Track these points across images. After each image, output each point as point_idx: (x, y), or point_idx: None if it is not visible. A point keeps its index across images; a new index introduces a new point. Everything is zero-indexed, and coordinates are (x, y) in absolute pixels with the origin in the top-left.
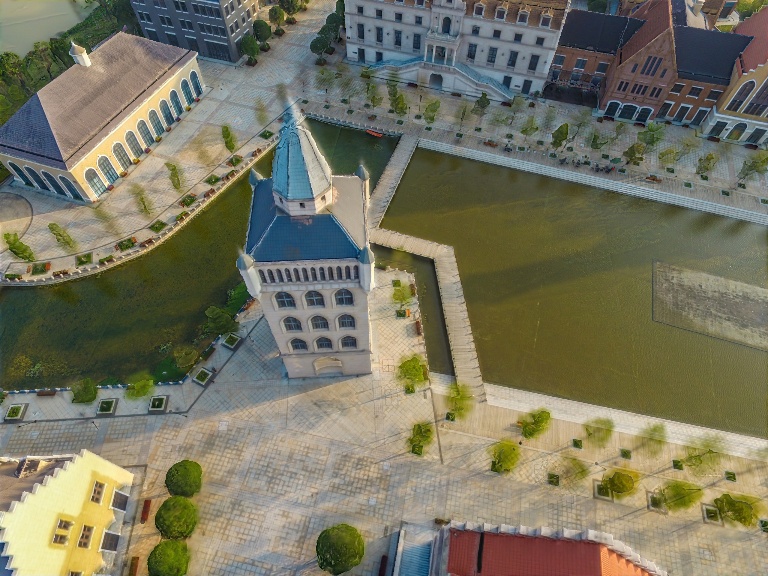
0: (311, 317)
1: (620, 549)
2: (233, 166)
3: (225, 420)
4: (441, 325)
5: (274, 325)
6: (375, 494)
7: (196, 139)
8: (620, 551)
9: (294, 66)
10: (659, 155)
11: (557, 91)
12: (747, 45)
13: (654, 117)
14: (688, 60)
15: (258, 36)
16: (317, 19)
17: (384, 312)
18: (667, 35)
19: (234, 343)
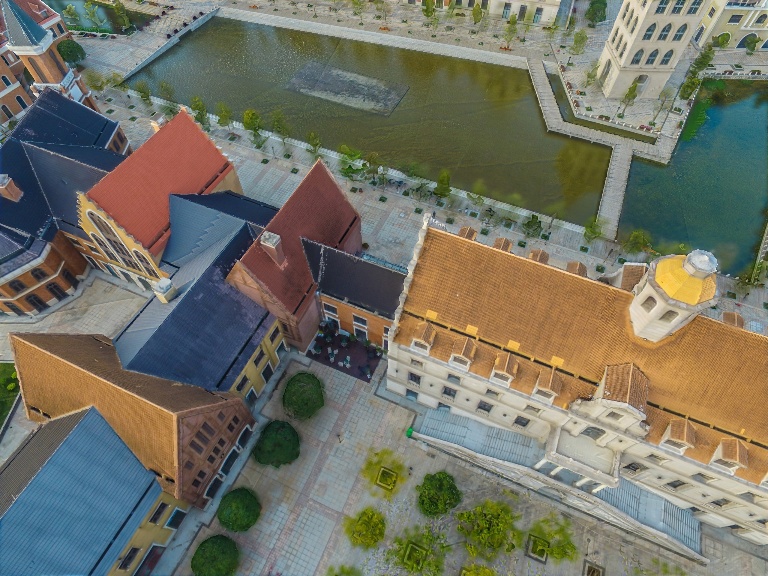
0: None
1: None
2: None
3: None
4: None
5: None
6: None
7: None
8: None
9: None
10: None
11: None
12: None
13: None
14: (262, 211)
15: None
16: None
17: (594, 95)
18: None
19: None
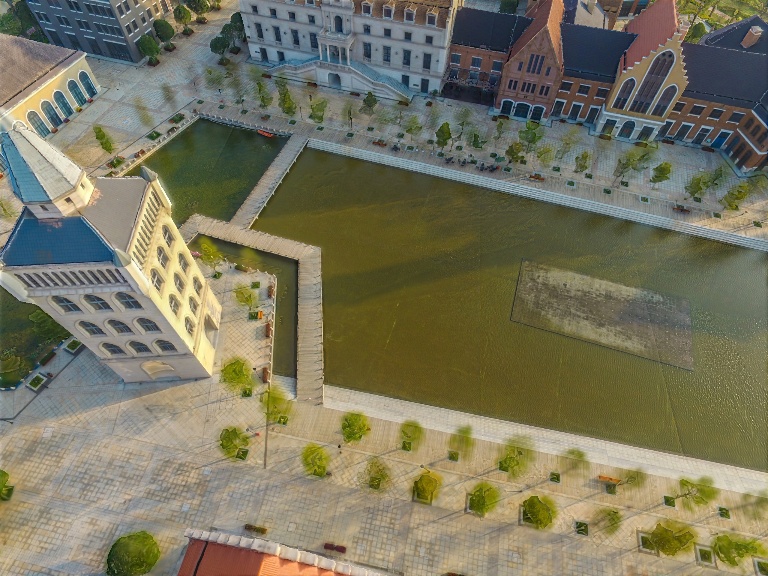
0: (105, 321)
1: (292, 558)
2: (113, 167)
3: (51, 426)
4: (294, 327)
5: (72, 330)
6: (190, 500)
7: (81, 140)
8: (291, 560)
9: (196, 66)
10: (537, 154)
11: (457, 90)
12: (632, 43)
13: (549, 115)
14: (575, 58)
15: (159, 36)
16: (229, 18)
17: (237, 314)
18: (544, 33)
19: (76, 347)
